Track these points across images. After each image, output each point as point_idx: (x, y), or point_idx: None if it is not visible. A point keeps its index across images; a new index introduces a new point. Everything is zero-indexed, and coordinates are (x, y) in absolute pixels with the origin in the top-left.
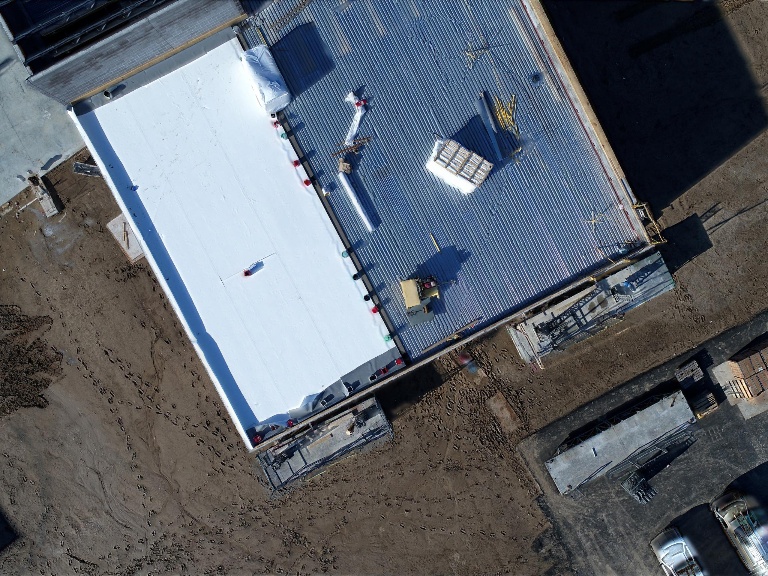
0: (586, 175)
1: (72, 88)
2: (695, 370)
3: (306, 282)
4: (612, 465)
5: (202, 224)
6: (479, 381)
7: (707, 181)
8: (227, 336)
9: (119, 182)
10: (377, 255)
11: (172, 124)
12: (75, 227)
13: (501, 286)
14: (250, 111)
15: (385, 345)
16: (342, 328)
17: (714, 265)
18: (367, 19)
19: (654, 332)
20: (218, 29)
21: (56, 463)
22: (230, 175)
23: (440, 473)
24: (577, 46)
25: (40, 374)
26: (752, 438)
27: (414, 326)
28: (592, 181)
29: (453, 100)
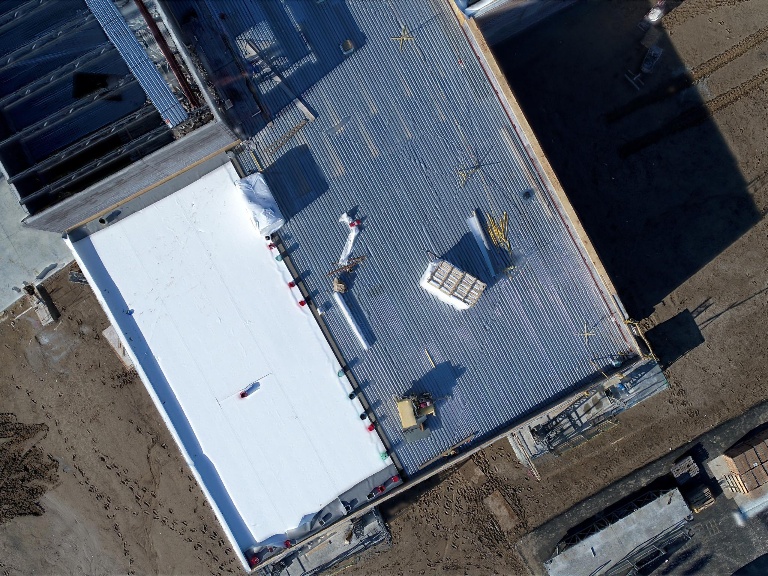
0: (578, 289)
1: (67, 220)
2: (691, 466)
3: (302, 401)
4: (611, 564)
5: (198, 346)
6: (476, 480)
7: (697, 277)
8: (224, 457)
9: (115, 307)
10: (373, 372)
11: (167, 248)
12: (71, 334)
13: (496, 400)
14: (245, 233)
15: (382, 462)
16: (339, 446)
17: (706, 359)
18: (359, 141)
19: (649, 427)
20: (212, 155)
21: (52, 571)
22: (225, 297)
23: (439, 572)
24: (566, 148)
25: (36, 482)
26: (749, 531)
27: (411, 442)
28: (584, 294)
29: (445, 218)
